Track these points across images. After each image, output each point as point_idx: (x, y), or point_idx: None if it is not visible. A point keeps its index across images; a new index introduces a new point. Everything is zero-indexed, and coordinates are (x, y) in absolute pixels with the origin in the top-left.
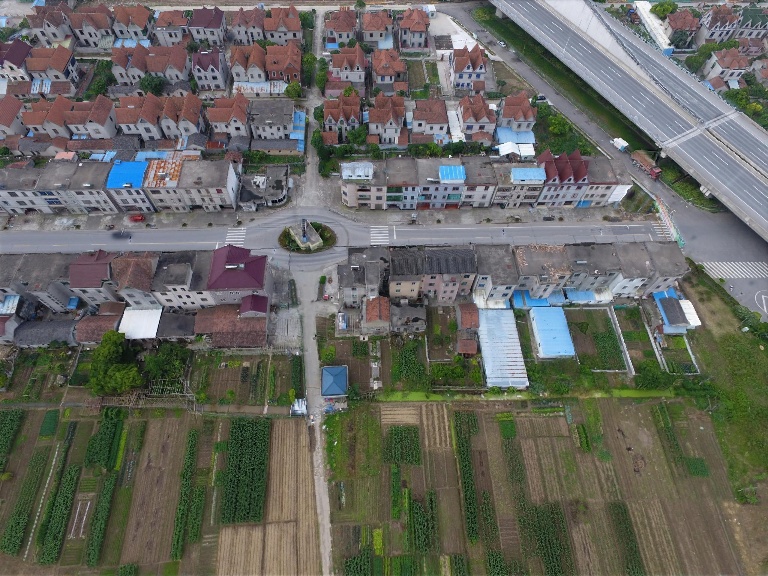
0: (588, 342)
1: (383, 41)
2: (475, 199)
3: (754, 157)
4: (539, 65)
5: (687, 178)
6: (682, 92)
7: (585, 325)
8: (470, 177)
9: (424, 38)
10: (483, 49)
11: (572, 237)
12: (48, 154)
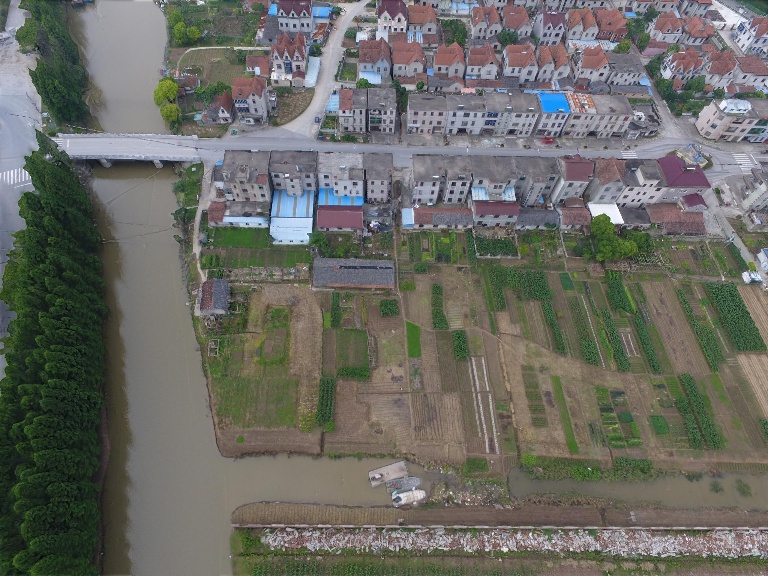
0: None
1: None
2: None
3: None
4: None
5: None
6: None
7: None
8: None
9: None
10: None
11: None
12: (448, 90)
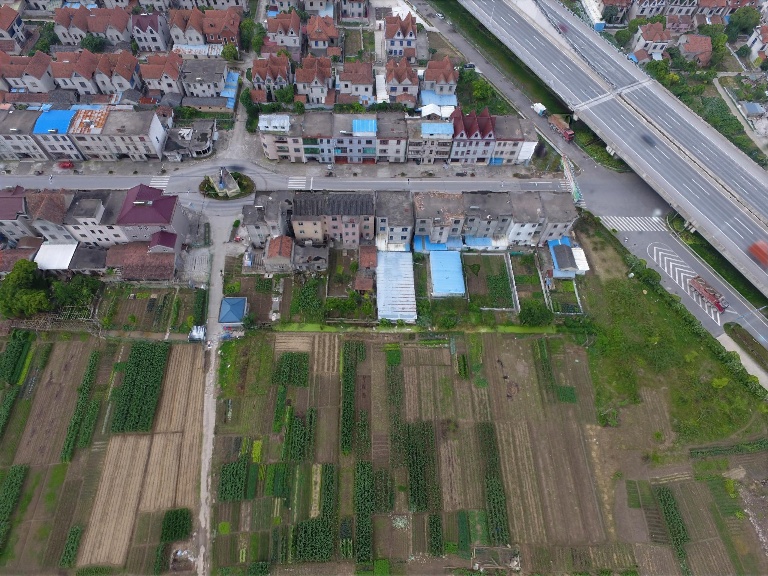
0: (481, 284)
1: (324, 10)
2: (390, 154)
3: (661, 121)
4: (473, 36)
5: (600, 141)
6: (601, 61)
7: (476, 266)
8: (383, 131)
9: (363, 8)
10: (414, 17)
11: None
12: None
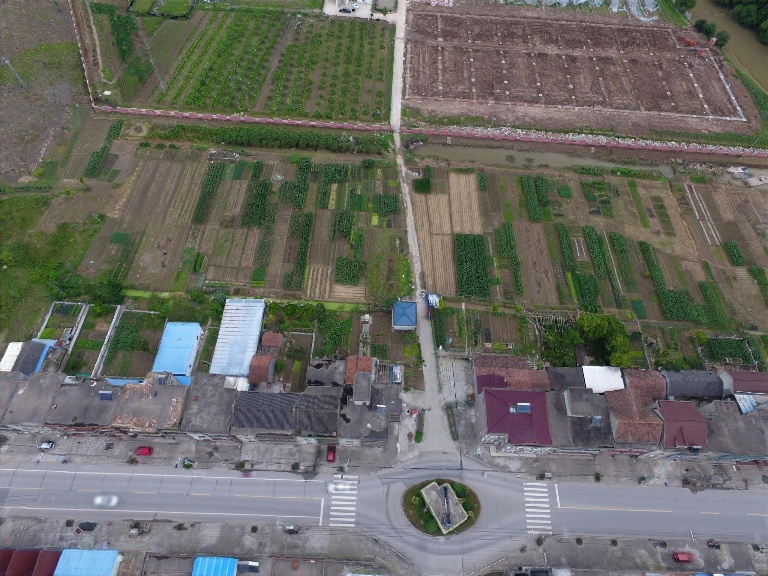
0: None
1: None
2: None
3: None
4: None
5: None
6: None
7: (141, 344)
8: None
9: None
10: None
11: (74, 487)
12: None
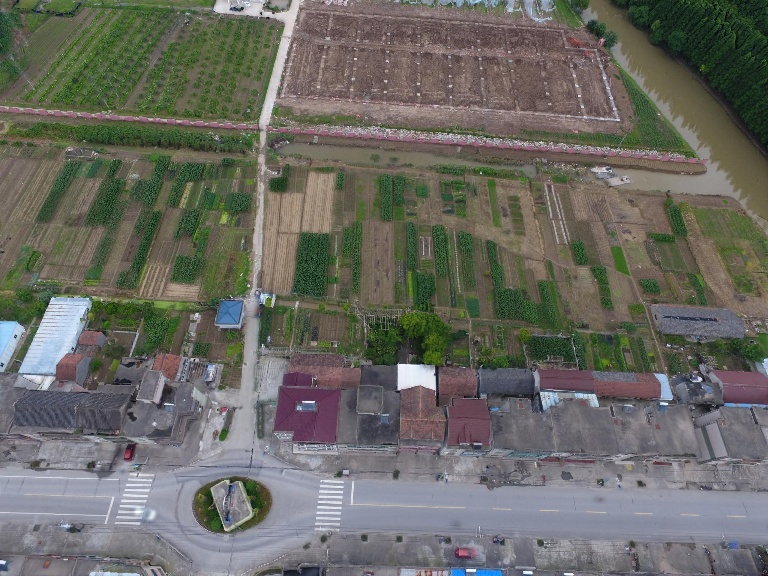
0: None
1: None
2: None
3: None
4: None
5: None
6: None
7: None
8: None
9: None
10: None
11: None
12: None
